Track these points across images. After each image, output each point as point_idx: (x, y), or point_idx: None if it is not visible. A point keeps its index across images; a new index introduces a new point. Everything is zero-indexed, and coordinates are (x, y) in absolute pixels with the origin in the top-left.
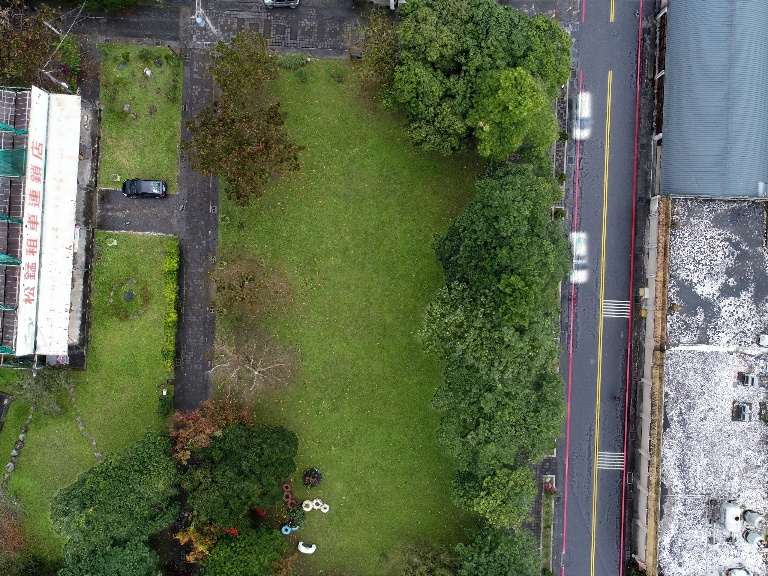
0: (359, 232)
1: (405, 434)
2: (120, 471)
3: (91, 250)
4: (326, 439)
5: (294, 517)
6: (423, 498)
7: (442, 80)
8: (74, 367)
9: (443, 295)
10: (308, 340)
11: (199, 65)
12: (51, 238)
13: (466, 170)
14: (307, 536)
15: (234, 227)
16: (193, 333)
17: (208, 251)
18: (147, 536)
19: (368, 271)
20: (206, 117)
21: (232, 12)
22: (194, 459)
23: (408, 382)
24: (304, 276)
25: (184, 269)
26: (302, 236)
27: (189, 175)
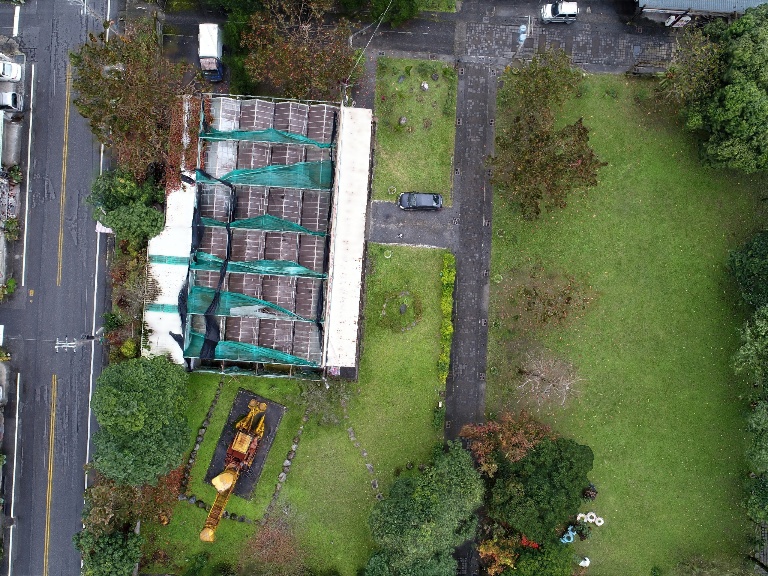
0: (632, 247)
1: (676, 448)
2: (443, 485)
3: (364, 262)
4: (599, 453)
5: (582, 531)
6: (695, 512)
7: (766, 99)
8: (345, 378)
9: (767, 313)
10: (581, 354)
11: (474, 79)
12: (342, 250)
13: (740, 186)
14: (579, 549)
15: (508, 241)
16: (465, 346)
17: (481, 264)
18: (454, 549)
19: (641, 286)
20: (518, 133)
21: (507, 27)
22: (498, 473)
23: (680, 397)
24: (577, 290)
25: (457, 282)
26: (576, 250)
27: (463, 188)
